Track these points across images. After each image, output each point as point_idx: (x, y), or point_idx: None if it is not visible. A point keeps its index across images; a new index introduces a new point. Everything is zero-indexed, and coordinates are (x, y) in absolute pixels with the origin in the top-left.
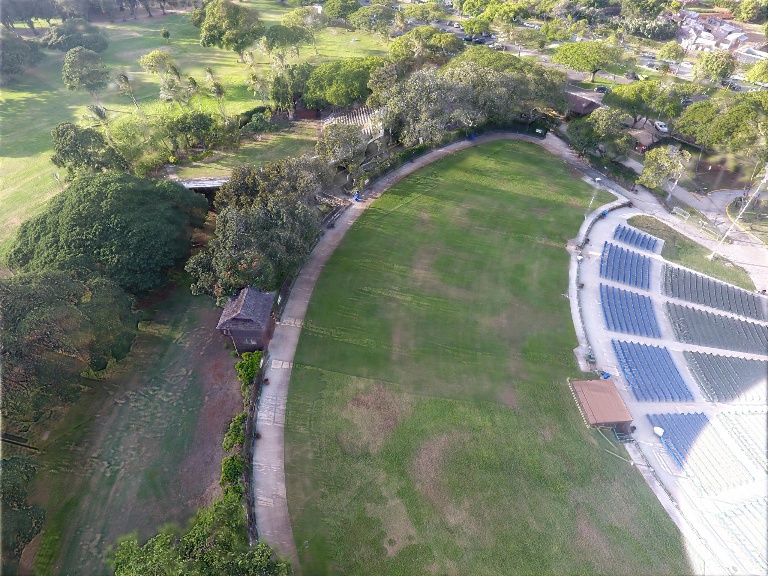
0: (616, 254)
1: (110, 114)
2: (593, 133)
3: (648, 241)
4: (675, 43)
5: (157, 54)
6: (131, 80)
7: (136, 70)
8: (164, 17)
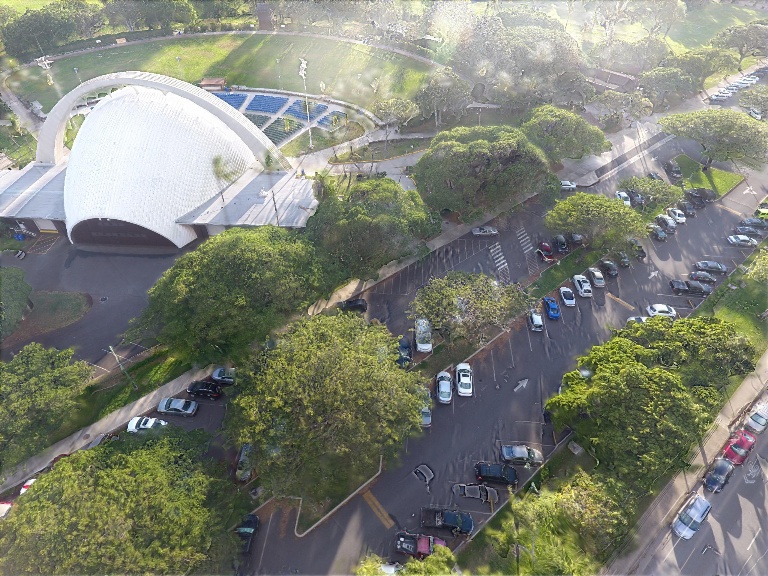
0: (315, 108)
1: (483, 7)
2: None
3: None
4: None
5: None
6: None
7: (558, 4)
8: None
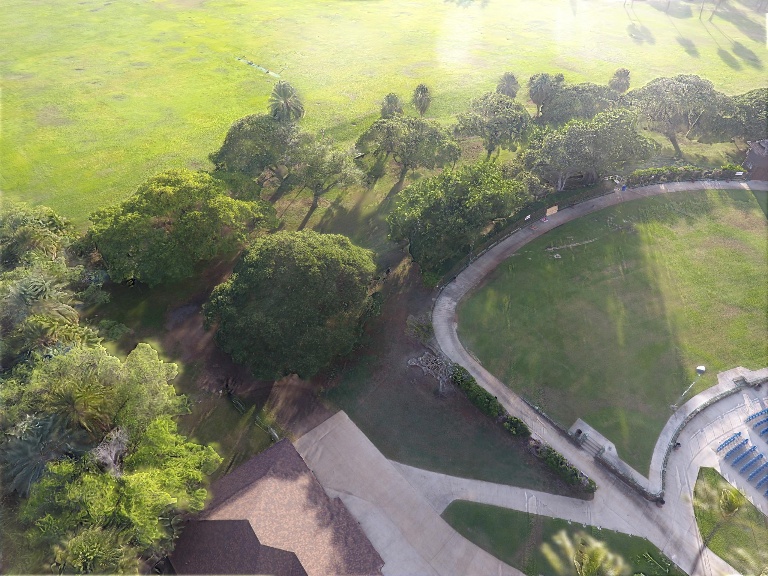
0: None
1: None
2: None
3: None
4: None
5: None
6: None
7: None
8: None
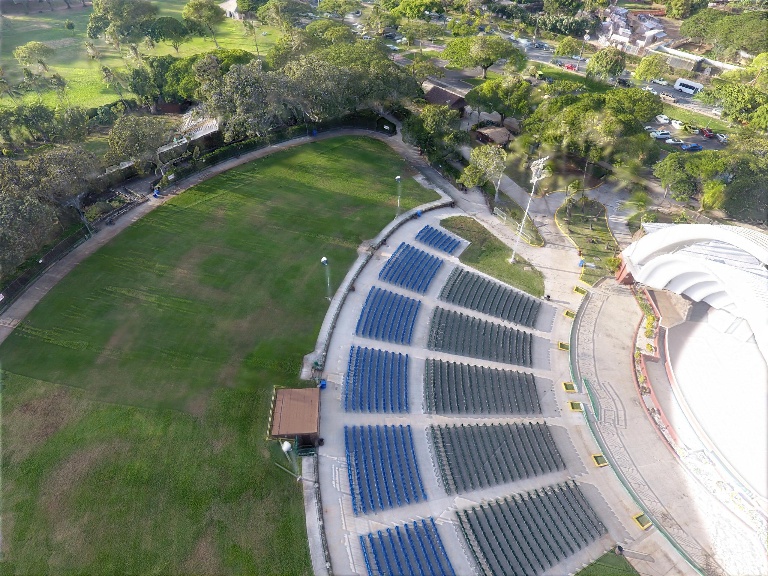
0: (408, 256)
1: None
2: (425, 130)
3: (449, 243)
4: (569, 39)
5: (31, 45)
6: (15, 72)
7: None
8: (83, 9)
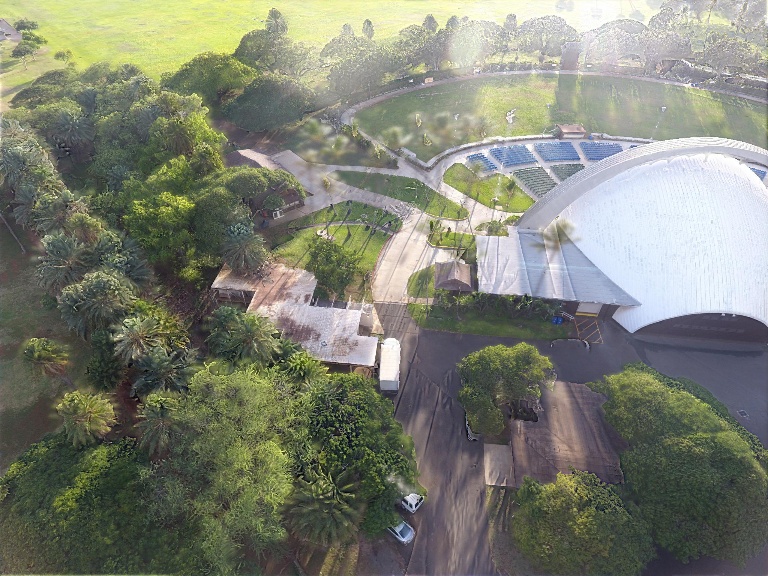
0: None
1: None
2: None
3: None
4: None
5: None
6: None
7: None
8: None
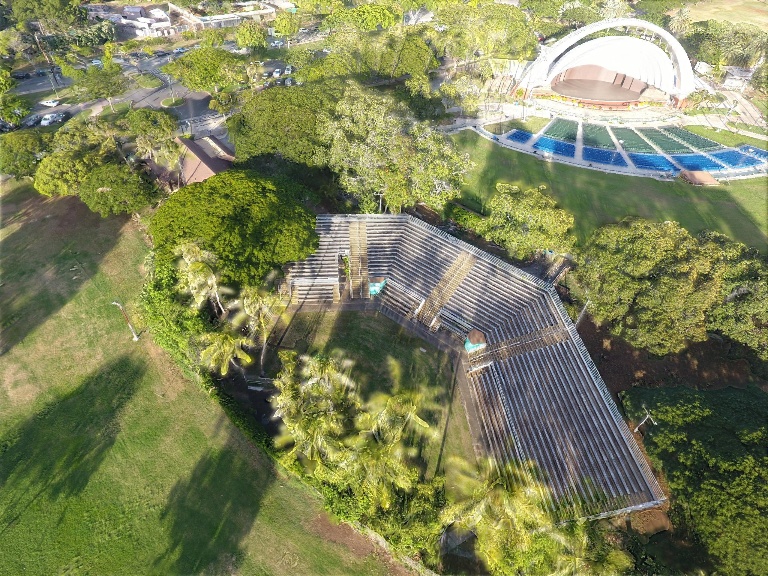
0: None
1: None
2: (423, 101)
3: (523, 133)
4: None
5: None
6: None
7: None
8: None
